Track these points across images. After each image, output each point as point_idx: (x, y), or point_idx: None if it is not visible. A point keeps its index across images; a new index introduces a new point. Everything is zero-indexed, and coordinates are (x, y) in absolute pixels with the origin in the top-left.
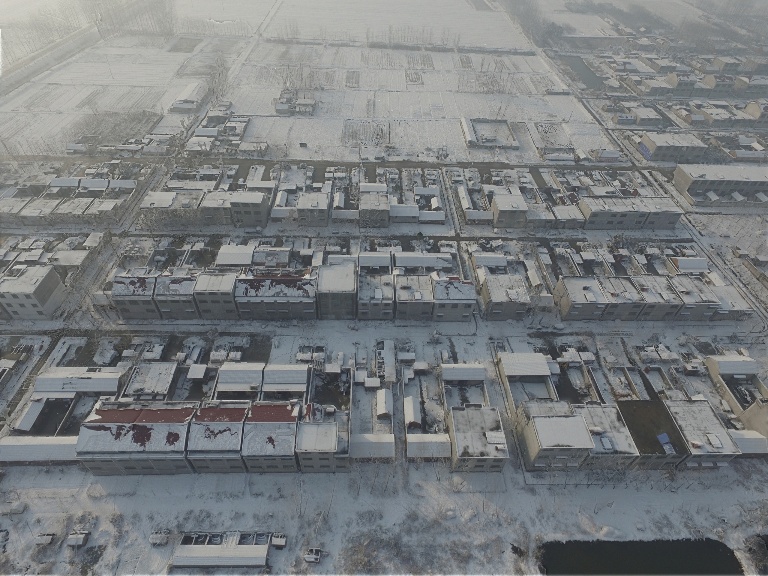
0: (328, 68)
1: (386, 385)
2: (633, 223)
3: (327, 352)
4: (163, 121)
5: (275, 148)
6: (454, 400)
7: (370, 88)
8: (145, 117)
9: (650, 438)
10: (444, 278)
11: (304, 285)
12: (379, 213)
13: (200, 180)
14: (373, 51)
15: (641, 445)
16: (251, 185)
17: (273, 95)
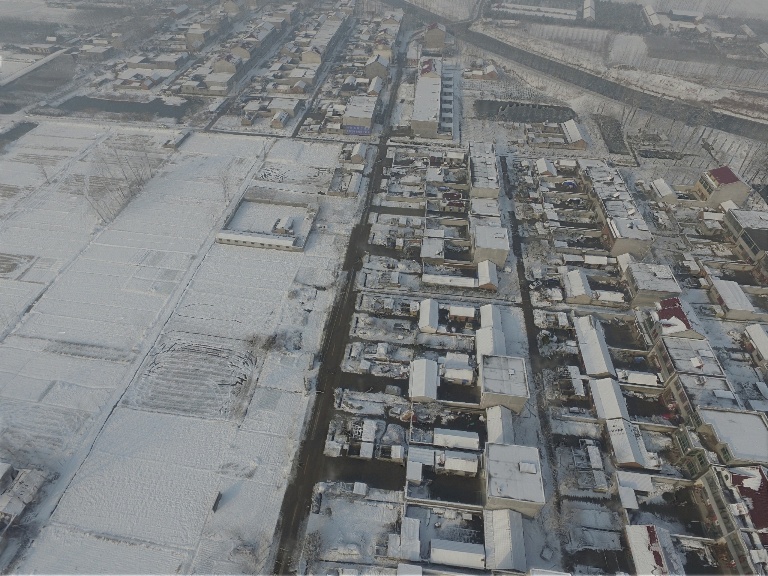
0: None
1: None
2: None
3: None
4: None
5: None
6: None
7: None
8: None
9: None
10: (674, 321)
11: None
12: None
13: None
14: None
15: None
16: None
17: None
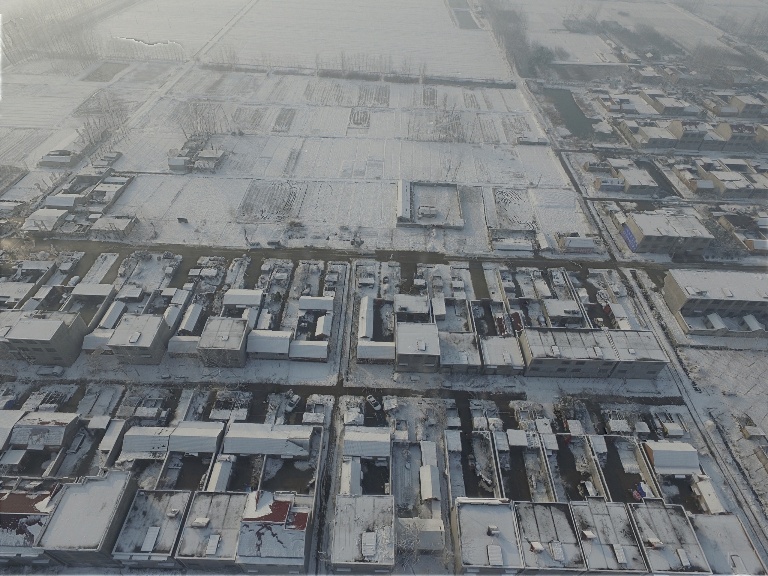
0: (260, 104)
1: None
2: (595, 371)
3: None
4: (24, 180)
5: (146, 224)
6: None
7: (301, 133)
8: (4, 174)
9: None
10: (263, 509)
11: (29, 525)
12: (225, 352)
13: (21, 277)
14: (322, 81)
15: None
16: (78, 291)
17: (178, 142)
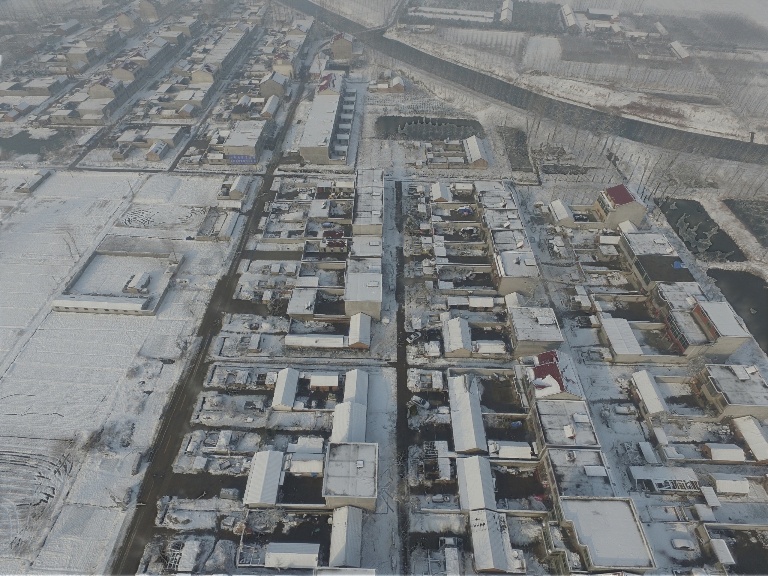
0: None
1: (706, 479)
2: None
3: (678, 568)
4: None
5: None
6: (677, 410)
7: None
8: None
9: (678, 272)
10: (548, 381)
11: None
12: None
13: None
14: None
15: (688, 279)
16: None
17: None
